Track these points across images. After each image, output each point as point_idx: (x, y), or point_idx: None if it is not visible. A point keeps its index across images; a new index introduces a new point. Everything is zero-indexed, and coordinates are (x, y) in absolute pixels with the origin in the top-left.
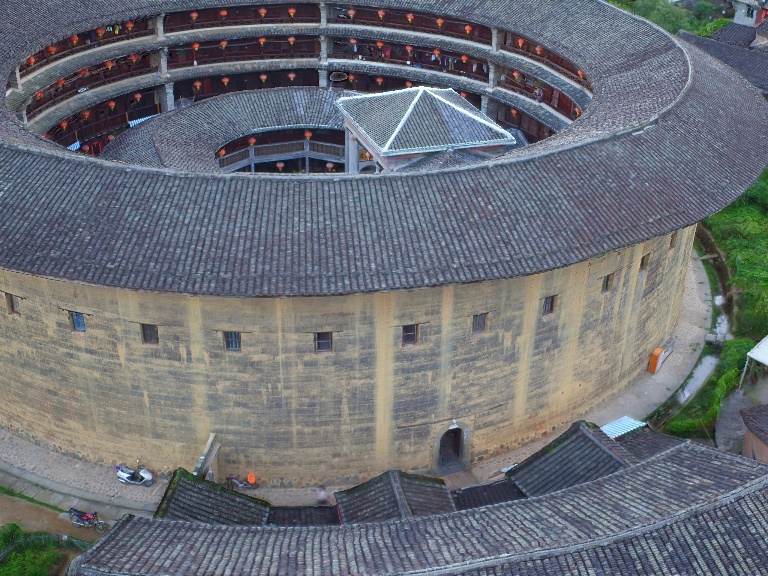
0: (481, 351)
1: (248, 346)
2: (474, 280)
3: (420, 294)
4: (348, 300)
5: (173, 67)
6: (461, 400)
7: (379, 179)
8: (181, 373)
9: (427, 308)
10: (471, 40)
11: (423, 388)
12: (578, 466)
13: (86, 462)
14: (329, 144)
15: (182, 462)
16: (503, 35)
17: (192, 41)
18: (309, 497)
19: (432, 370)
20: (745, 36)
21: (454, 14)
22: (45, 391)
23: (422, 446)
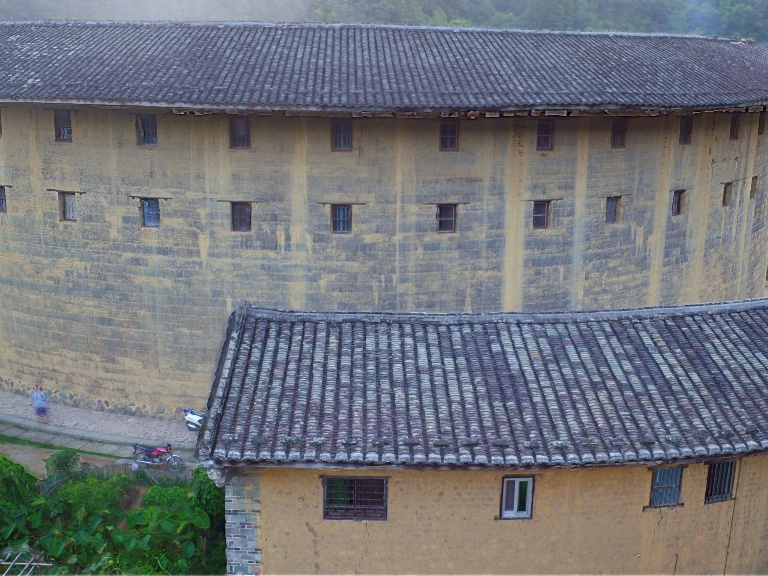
0: (614, 247)
1: (360, 223)
2: (633, 104)
3: (553, 160)
4: (477, 161)
5: None
6: None
7: (501, 33)
8: (276, 267)
9: (560, 180)
10: None
11: (554, 288)
12: None
13: (141, 417)
14: None
15: None
16: None
17: None
18: None
19: (564, 265)
20: None
21: None
22: (96, 321)
23: None
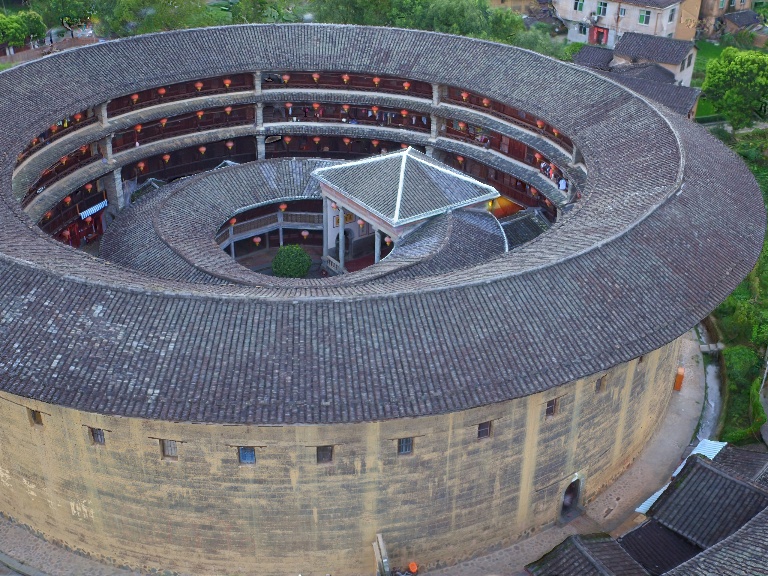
0: (599, 409)
1: (421, 448)
2: (636, 357)
3: None
4: None
5: (116, 151)
6: (582, 455)
7: (522, 275)
8: (354, 485)
9: None
10: (408, 95)
11: (557, 452)
12: (709, 495)
13: None
14: (304, 213)
15: (345, 567)
16: (442, 89)
17: (136, 123)
18: (466, 572)
19: (565, 434)
20: (602, 57)
21: (393, 73)
22: (198, 527)
23: (552, 502)
